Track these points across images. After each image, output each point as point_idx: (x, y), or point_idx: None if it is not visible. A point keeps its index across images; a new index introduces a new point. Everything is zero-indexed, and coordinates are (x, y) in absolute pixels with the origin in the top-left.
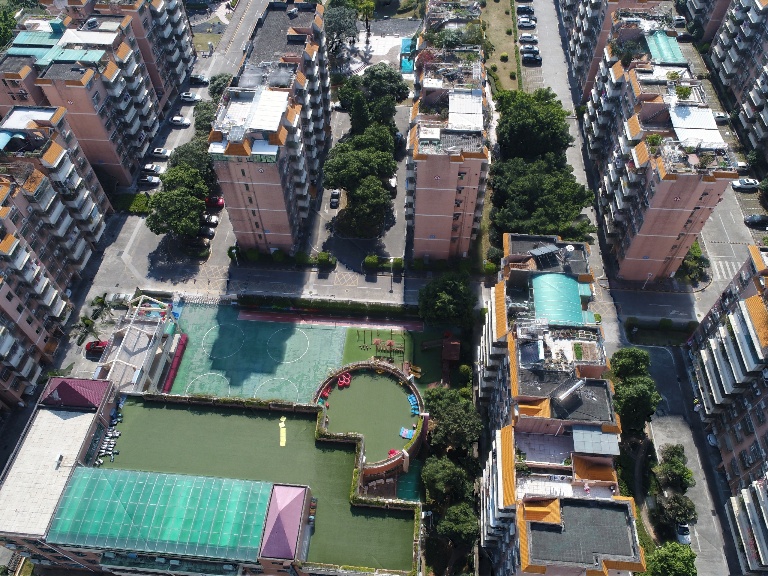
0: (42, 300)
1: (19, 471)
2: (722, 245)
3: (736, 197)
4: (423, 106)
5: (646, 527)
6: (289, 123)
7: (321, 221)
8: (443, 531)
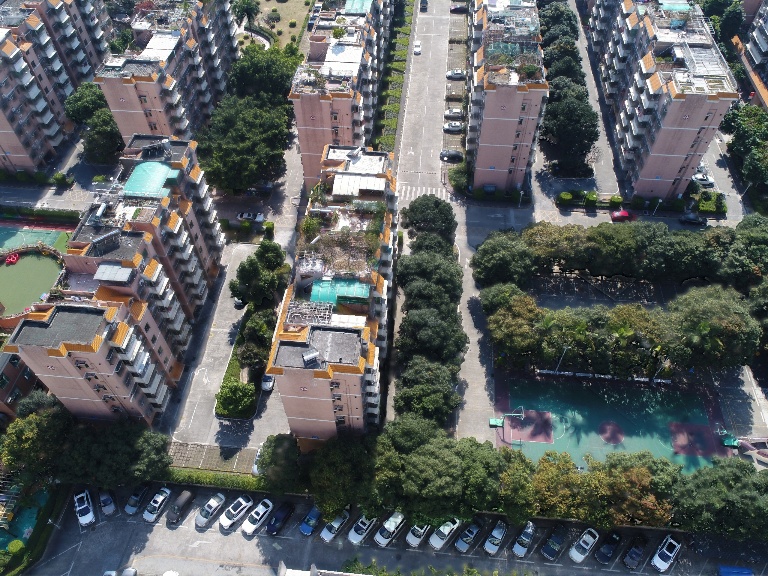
0: None
1: None
2: (412, 174)
3: (443, 137)
4: None
5: (243, 378)
6: (5, 54)
7: (75, 151)
8: None
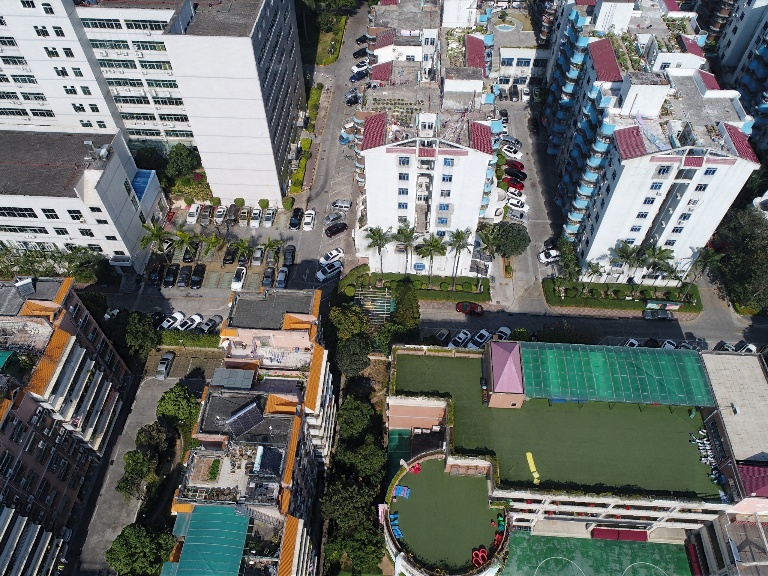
0: None
1: (766, 402)
2: None
3: None
4: None
5: (181, 449)
6: None
7: None
8: (369, 405)
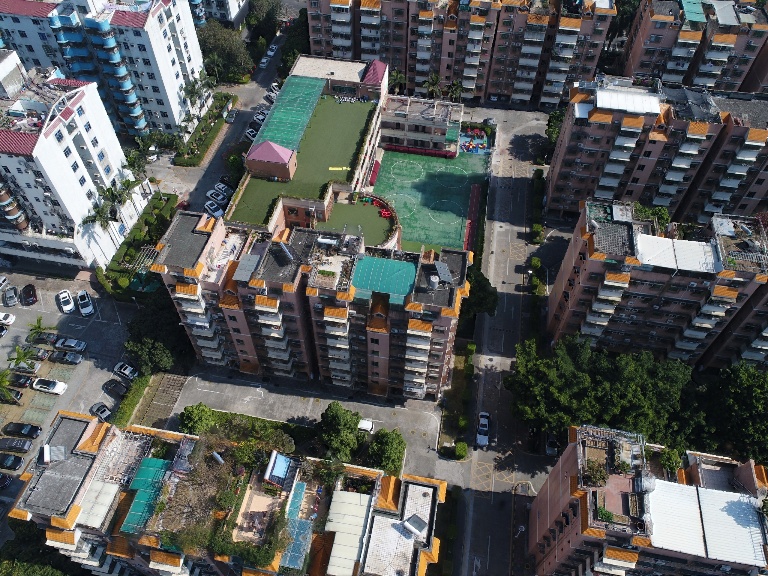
0: (464, 68)
1: (329, 63)
2: None
3: None
4: (698, 234)
5: None
6: (622, 123)
7: None
8: None
